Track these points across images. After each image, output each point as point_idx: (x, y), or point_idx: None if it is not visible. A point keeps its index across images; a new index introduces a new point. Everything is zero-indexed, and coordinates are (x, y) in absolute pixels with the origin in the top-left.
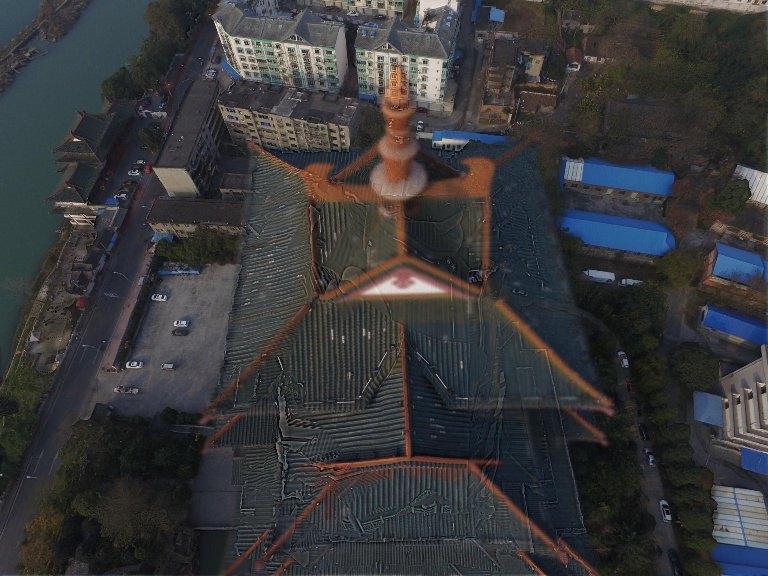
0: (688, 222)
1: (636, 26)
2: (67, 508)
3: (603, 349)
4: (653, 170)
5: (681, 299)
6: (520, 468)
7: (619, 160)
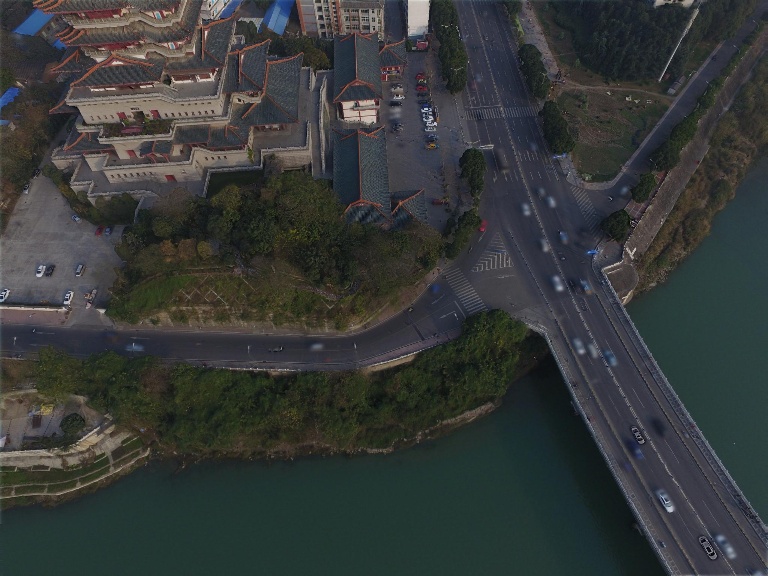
0: None
1: None
2: None
3: None
4: None
5: None
6: None
7: (21, 19)
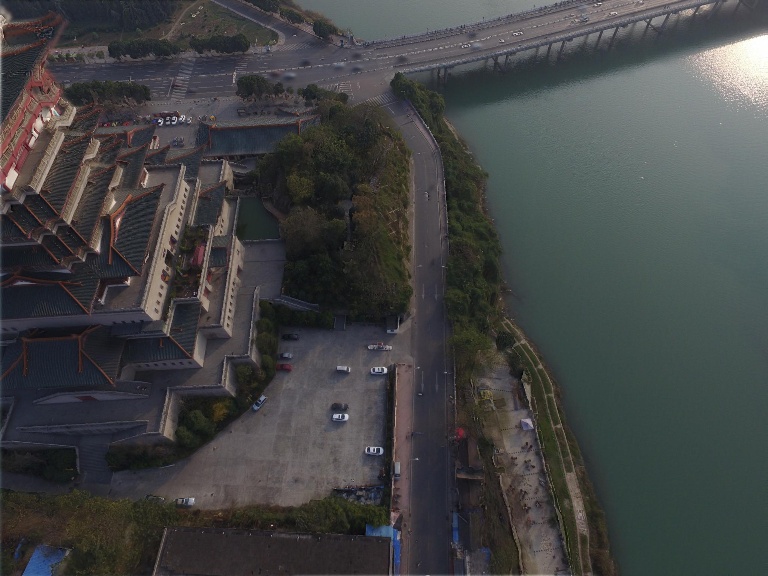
0: None
1: None
2: None
3: None
4: None
5: None
6: None
7: None
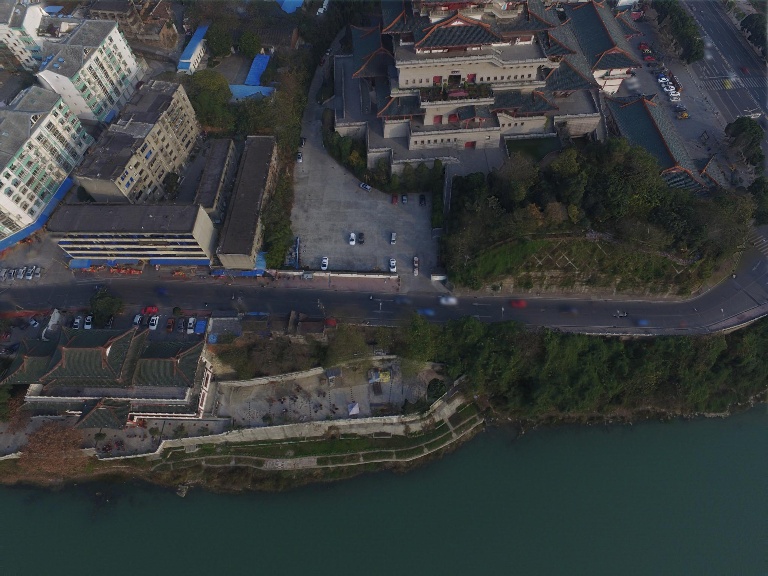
0: None
1: None
2: None
3: None
4: None
5: None
6: None
7: None
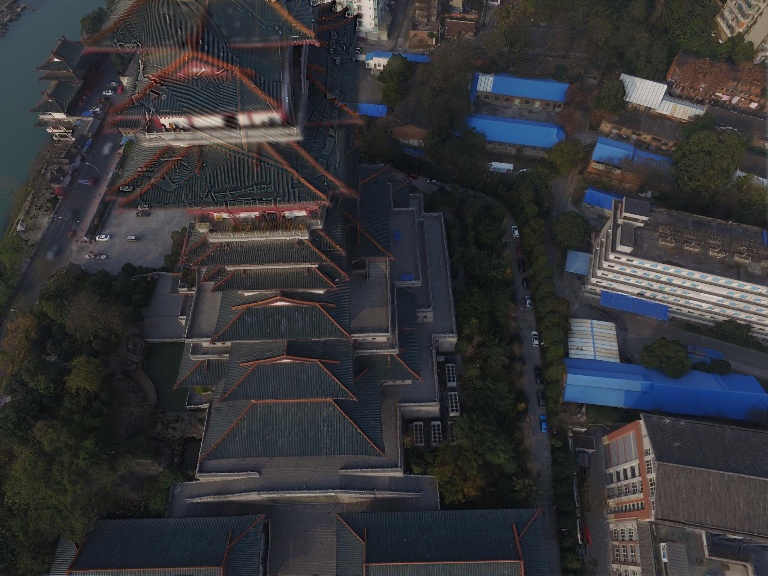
0: (582, 125)
1: None
2: (41, 316)
3: (493, 217)
4: (553, 81)
5: (570, 185)
6: (378, 248)
7: (524, 74)
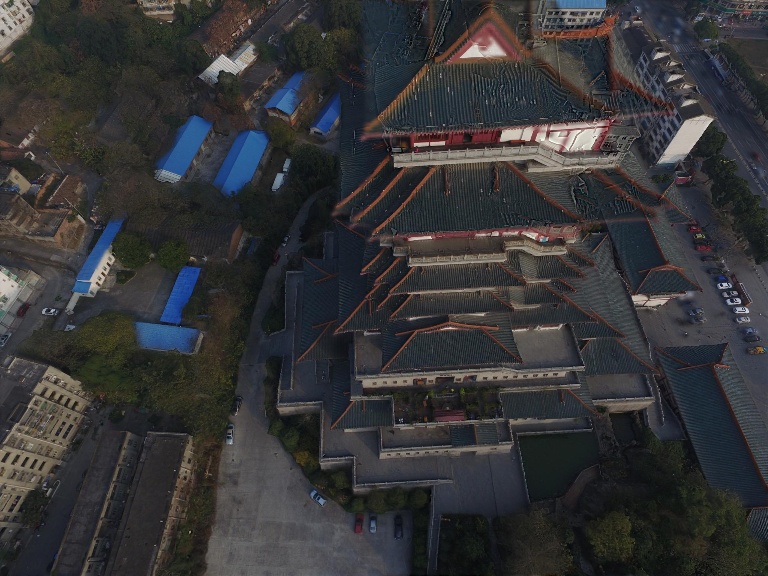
0: None
1: (10, 94)
2: None
3: None
4: (184, 127)
5: None
6: None
7: (167, 145)
